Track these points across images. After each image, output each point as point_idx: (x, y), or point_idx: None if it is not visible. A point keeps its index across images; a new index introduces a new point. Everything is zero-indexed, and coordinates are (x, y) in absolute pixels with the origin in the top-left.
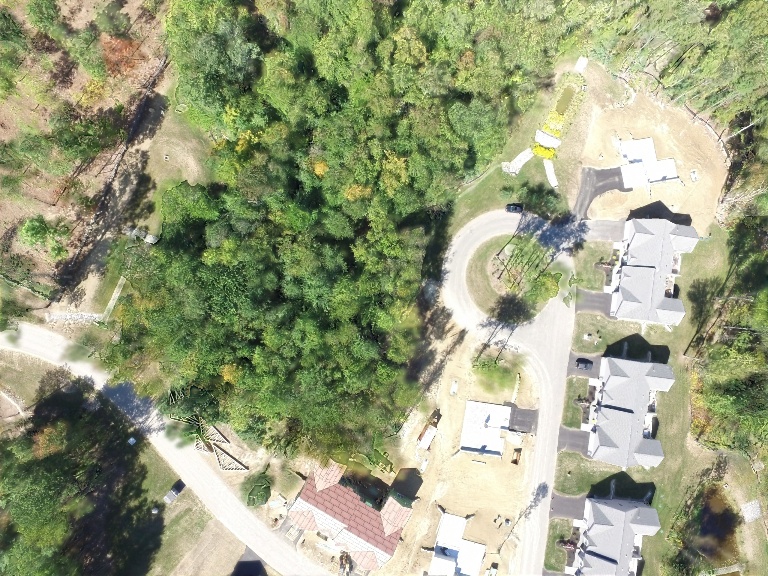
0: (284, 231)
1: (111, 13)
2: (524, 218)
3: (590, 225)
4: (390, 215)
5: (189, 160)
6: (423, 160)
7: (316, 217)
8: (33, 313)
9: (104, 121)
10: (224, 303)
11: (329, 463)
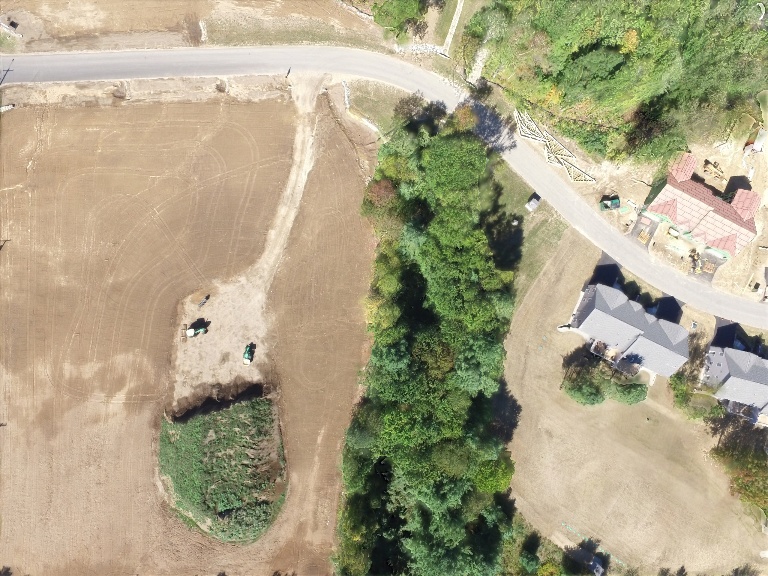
0: None
1: None
2: None
3: None
4: None
5: None
6: None
7: None
8: (383, 45)
9: None
10: None
11: (685, 156)
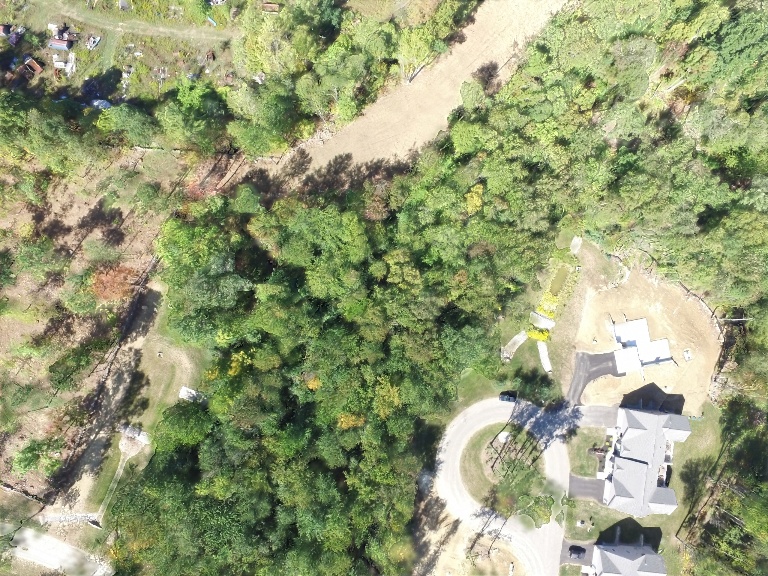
0: (277, 458)
1: (103, 208)
2: (518, 406)
3: (583, 411)
4: (383, 437)
5: (182, 357)
6: (416, 391)
7: (309, 435)
8: (27, 516)
9: (97, 319)
10: (218, 539)
11: None
